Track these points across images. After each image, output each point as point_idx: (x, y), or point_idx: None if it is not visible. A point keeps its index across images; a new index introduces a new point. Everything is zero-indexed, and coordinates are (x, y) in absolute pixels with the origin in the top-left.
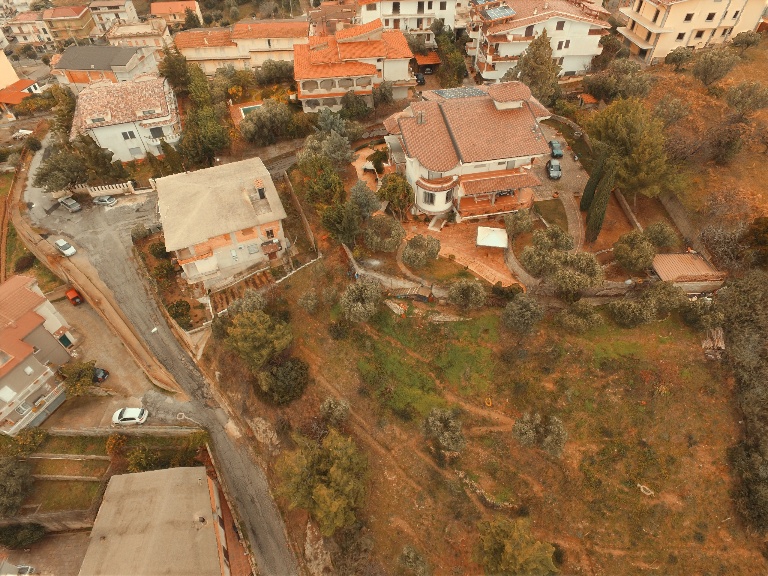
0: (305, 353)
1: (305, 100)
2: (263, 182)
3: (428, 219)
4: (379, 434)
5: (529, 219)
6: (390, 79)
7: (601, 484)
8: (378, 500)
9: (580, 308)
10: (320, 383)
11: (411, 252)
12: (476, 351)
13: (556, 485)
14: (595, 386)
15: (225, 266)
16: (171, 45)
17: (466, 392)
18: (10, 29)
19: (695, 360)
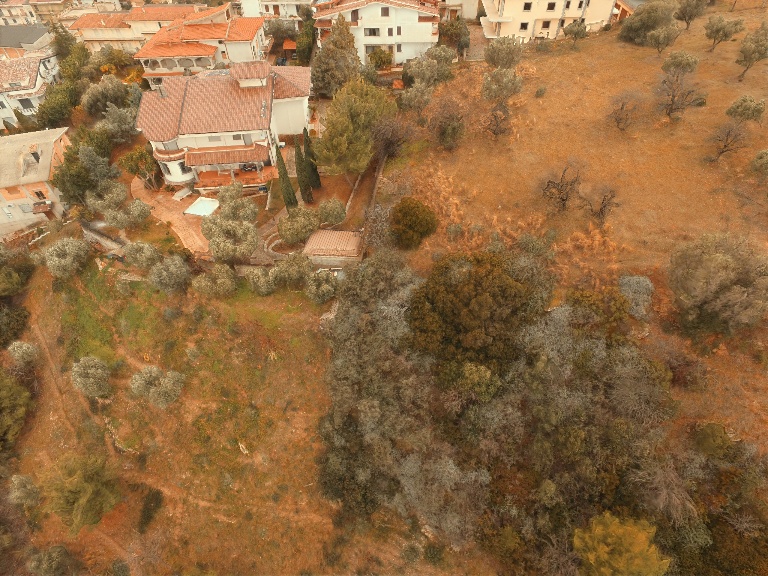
0: (32, 303)
1: (149, 78)
2: (43, 147)
3: (173, 189)
4: (60, 379)
5: (233, 191)
6: (236, 61)
7: (209, 440)
8: (37, 436)
9: (214, 273)
10: (34, 330)
11: (109, 214)
12: (145, 309)
13: (171, 437)
14: (225, 348)
15: (2, 222)
16: (58, 24)
17: (131, 346)
18: (1, 12)
19: (309, 330)
